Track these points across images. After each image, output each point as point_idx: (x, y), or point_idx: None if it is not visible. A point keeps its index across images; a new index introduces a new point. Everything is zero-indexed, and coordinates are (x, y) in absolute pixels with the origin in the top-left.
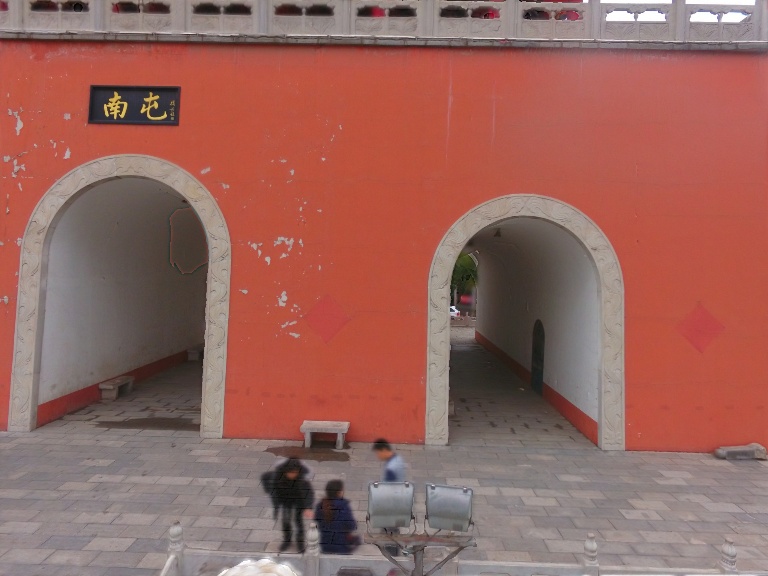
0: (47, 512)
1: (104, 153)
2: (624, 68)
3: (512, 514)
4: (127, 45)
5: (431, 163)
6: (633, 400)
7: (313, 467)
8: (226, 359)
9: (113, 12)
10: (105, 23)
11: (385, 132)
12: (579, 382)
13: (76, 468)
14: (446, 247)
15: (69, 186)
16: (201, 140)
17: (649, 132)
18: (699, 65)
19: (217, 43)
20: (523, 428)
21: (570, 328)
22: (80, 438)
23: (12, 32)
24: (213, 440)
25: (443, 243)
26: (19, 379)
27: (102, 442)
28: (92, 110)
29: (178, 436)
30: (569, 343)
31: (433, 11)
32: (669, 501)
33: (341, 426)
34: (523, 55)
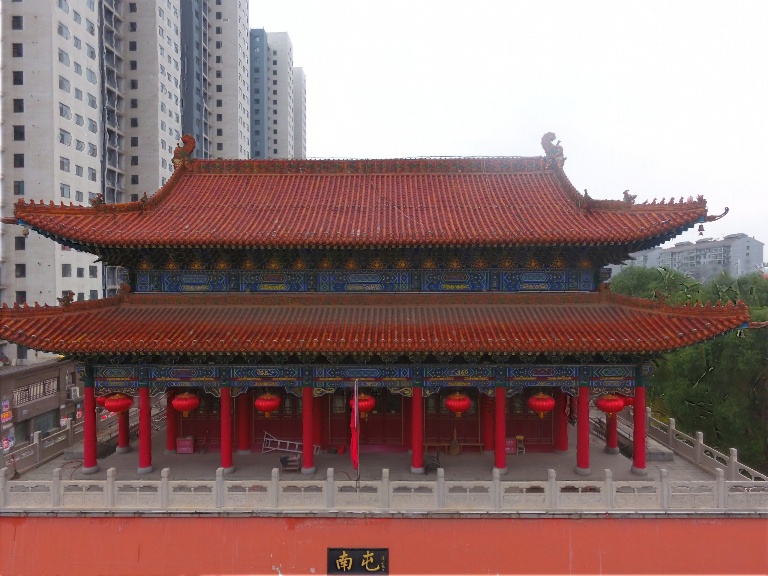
0: None
1: None
2: (686, 530)
3: None
4: (351, 519)
5: None
6: None
7: None
8: None
9: (339, 492)
10: (334, 501)
11: None
12: None
13: None
14: None
15: None
16: None
17: (705, 574)
18: (736, 528)
19: (412, 518)
20: None
21: None
22: None
23: (273, 512)
24: None
25: None
26: None
27: None
28: (329, 565)
29: None
30: None
31: (556, 490)
32: None
33: None
34: (618, 522)
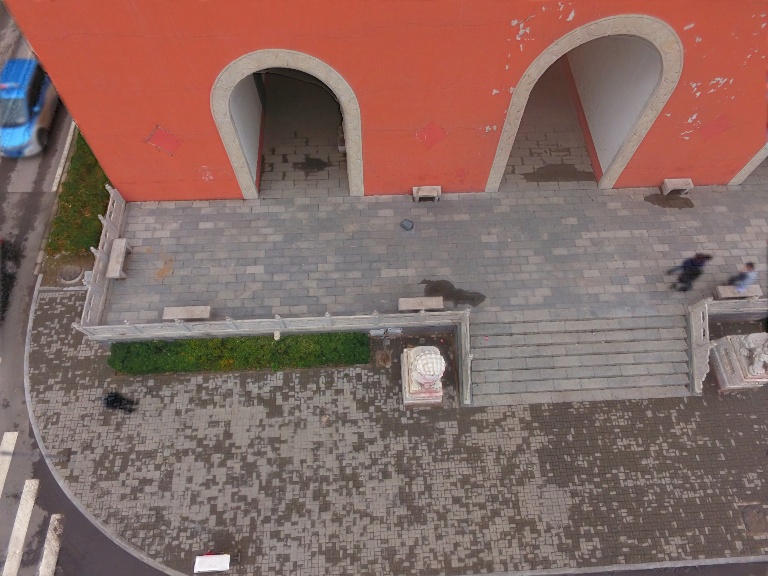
0: (592, 263)
1: (605, 14)
2: None
3: None
4: None
5: None
6: None
7: (680, 215)
8: None
9: None
10: None
11: None
12: None
13: (566, 227)
14: None
15: (565, 46)
16: None
17: None
18: None
19: None
20: None
21: None
22: (534, 196)
23: None
24: (608, 191)
25: None
26: (496, 169)
27: (550, 199)
28: None
29: (585, 189)
30: None
31: None
32: None
33: (690, 185)
34: None
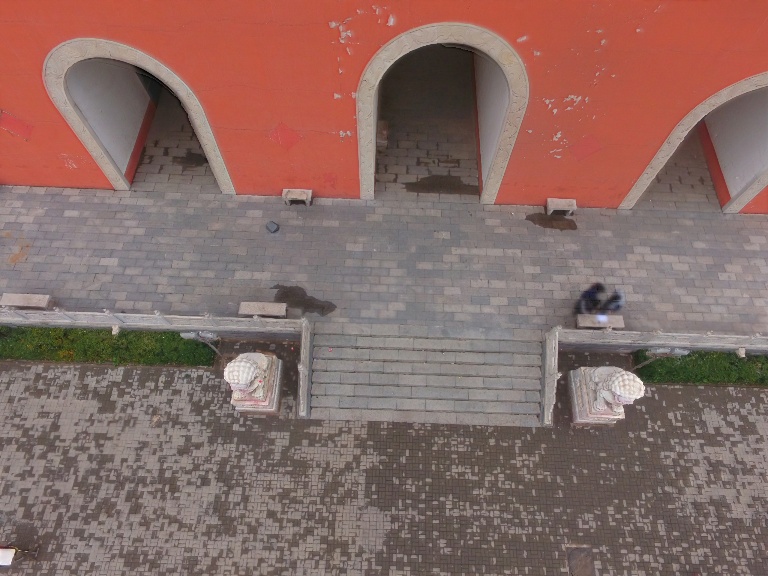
0: (455, 280)
1: (426, 20)
2: None
3: (667, 278)
4: None
5: (739, 35)
6: (764, 192)
7: (560, 237)
8: (506, 169)
9: None
10: None
11: (714, 3)
12: (736, 163)
13: (437, 241)
14: (704, 106)
15: (393, 52)
16: (524, 8)
17: None
18: None
19: None
20: (678, 184)
21: (757, 119)
22: (411, 207)
23: None
24: (489, 207)
25: (704, 103)
26: (365, 176)
27: (427, 211)
28: None
29: (466, 203)
30: (748, 127)
31: None
32: (745, 265)
33: (573, 206)
34: None
